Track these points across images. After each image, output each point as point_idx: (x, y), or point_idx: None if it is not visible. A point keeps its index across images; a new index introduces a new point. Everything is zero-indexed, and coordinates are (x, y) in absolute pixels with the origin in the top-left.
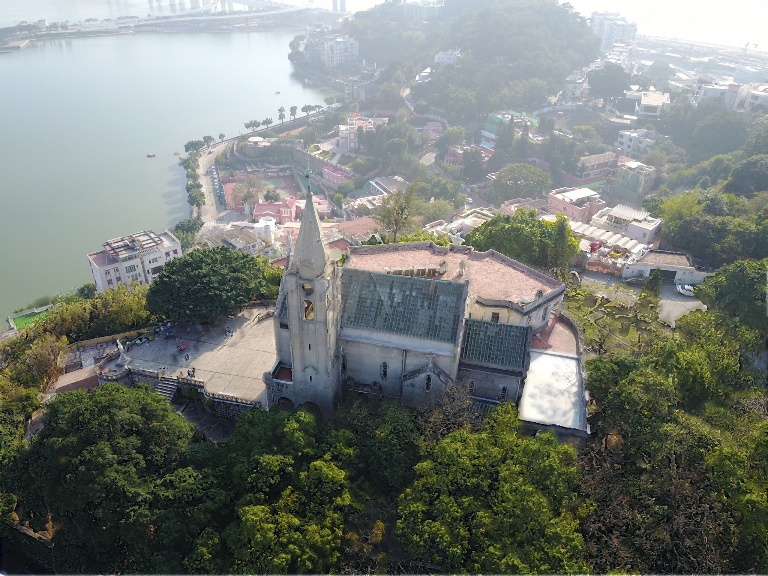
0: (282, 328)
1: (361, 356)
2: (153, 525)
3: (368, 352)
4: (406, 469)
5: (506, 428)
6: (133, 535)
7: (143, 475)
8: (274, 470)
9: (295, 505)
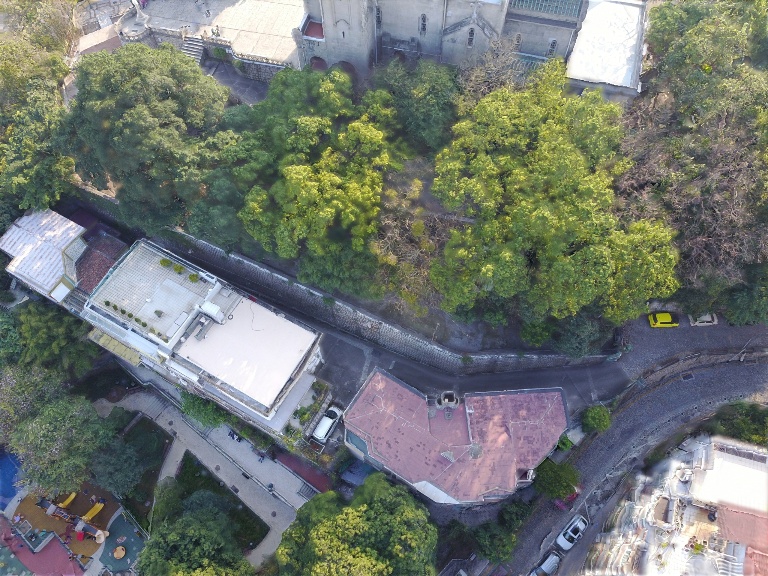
0: None
1: (397, 7)
2: (205, 183)
3: (405, 2)
4: (444, 130)
5: (551, 86)
6: (188, 192)
7: (186, 138)
8: (313, 131)
9: (336, 165)
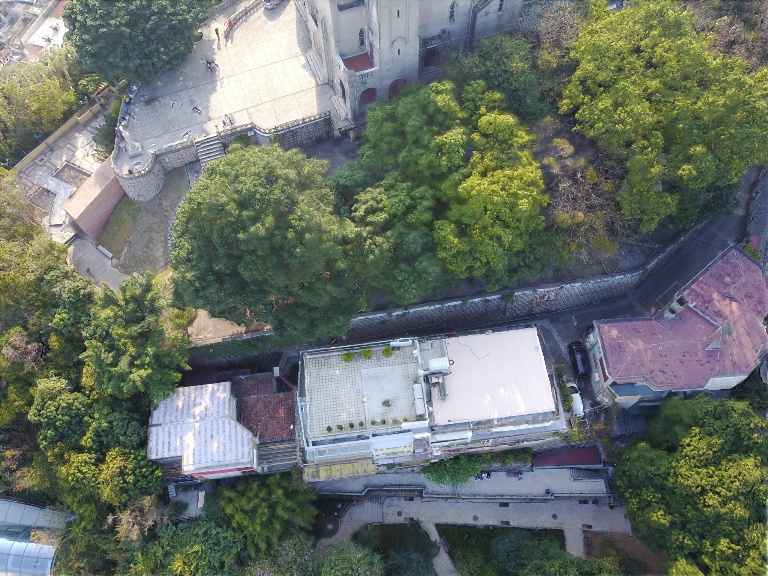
0: (343, 10)
1: (429, 5)
2: (393, 246)
3: None
4: None
5: None
6: None
7: None
8: None
9: (494, 162)
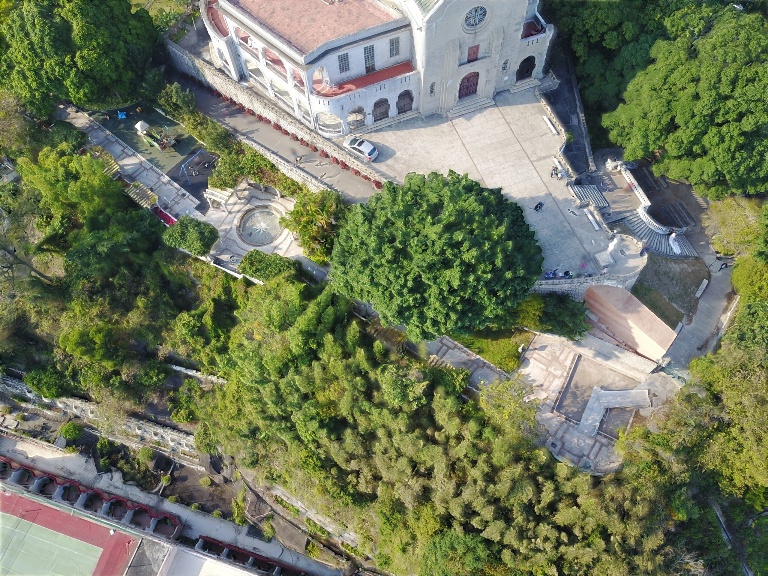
0: None
1: None
2: None
3: None
4: None
5: None
6: None
7: None
8: None
9: None
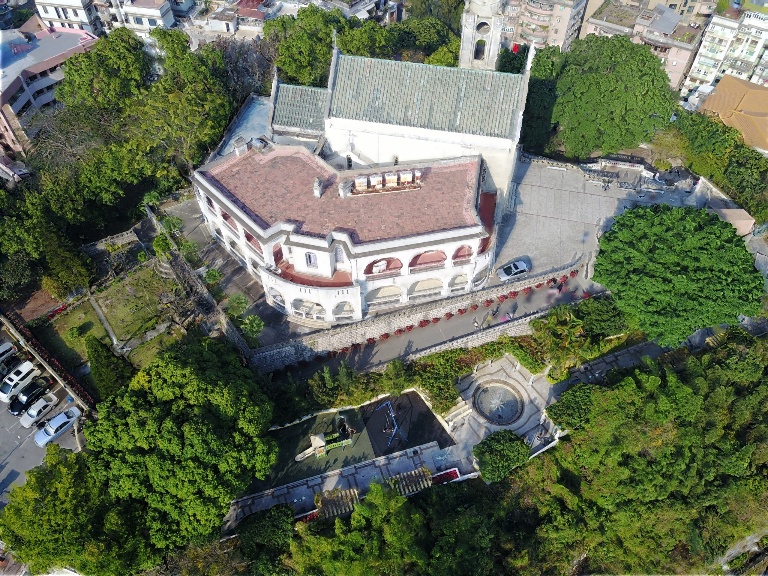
0: None
1: None
2: None
3: None
4: None
5: None
6: None
7: None
8: None
9: None
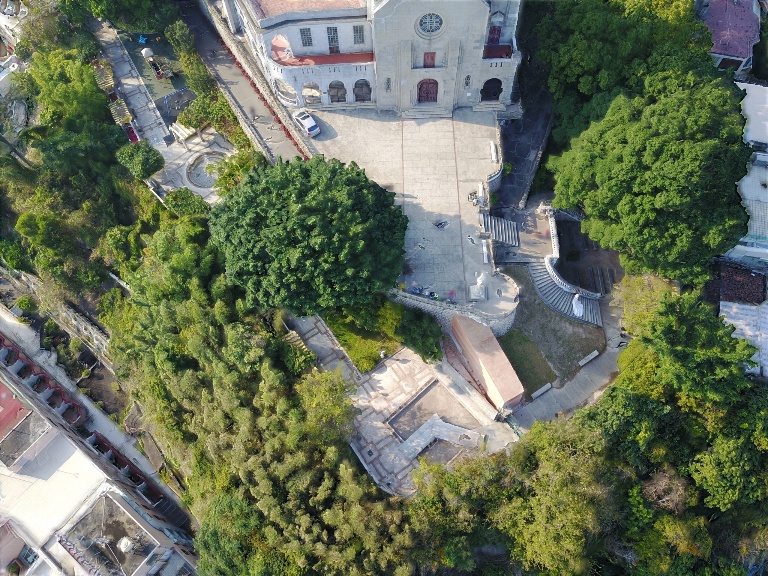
0: (491, 9)
1: None
2: None
3: None
4: None
5: None
6: None
7: None
8: None
9: None
